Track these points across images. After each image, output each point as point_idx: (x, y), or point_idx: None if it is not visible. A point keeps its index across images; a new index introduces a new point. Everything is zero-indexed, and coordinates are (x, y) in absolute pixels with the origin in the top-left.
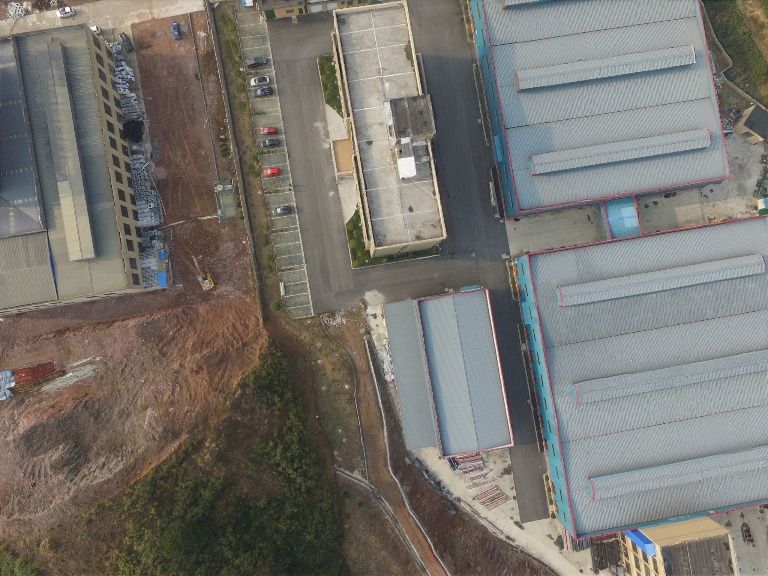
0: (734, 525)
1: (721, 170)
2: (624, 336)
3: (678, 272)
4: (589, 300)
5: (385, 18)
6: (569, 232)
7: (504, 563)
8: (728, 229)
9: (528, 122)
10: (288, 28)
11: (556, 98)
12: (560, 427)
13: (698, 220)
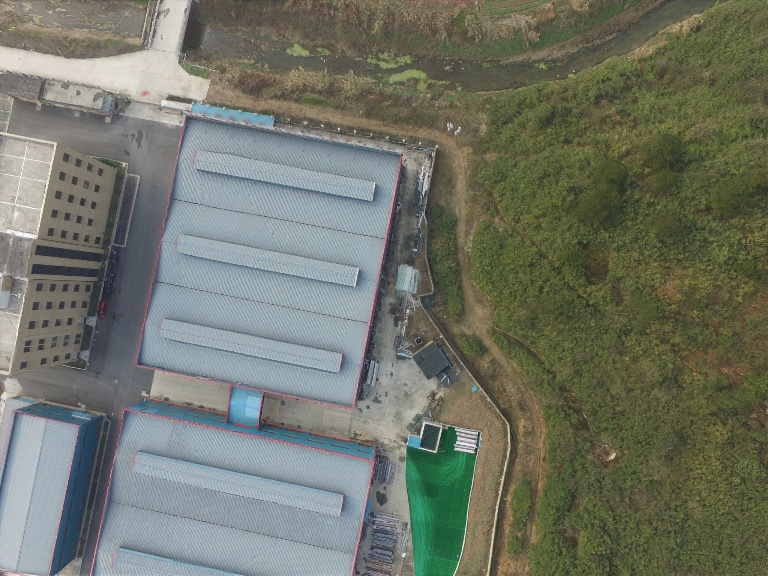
0: None
1: (350, 398)
2: (190, 521)
3: (253, 483)
4: (158, 476)
5: (38, 151)
6: (213, 394)
7: None
8: (331, 458)
9: (181, 283)
10: (30, 112)
11: (215, 270)
12: None
13: (343, 430)
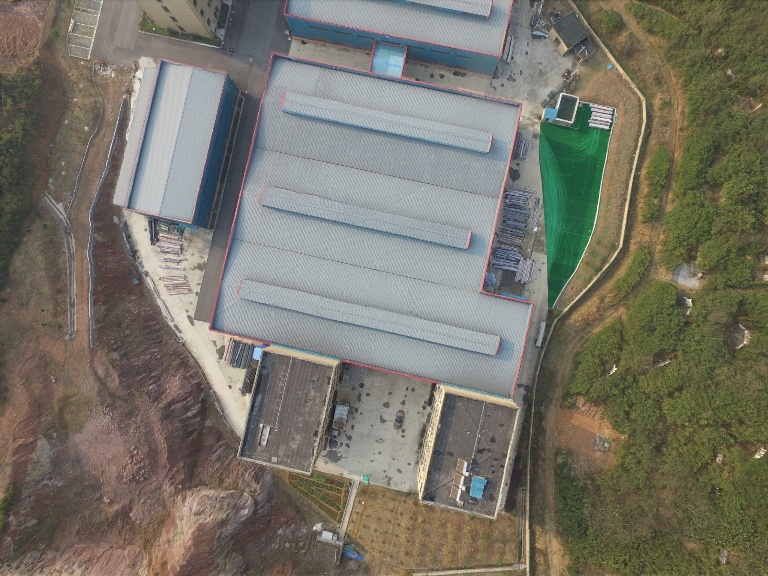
0: (392, 409)
1: (496, 49)
2: (334, 165)
3: (403, 119)
4: (308, 112)
5: None
6: None
7: (160, 345)
8: (477, 104)
9: None
10: None
11: None
12: (240, 224)
13: None
